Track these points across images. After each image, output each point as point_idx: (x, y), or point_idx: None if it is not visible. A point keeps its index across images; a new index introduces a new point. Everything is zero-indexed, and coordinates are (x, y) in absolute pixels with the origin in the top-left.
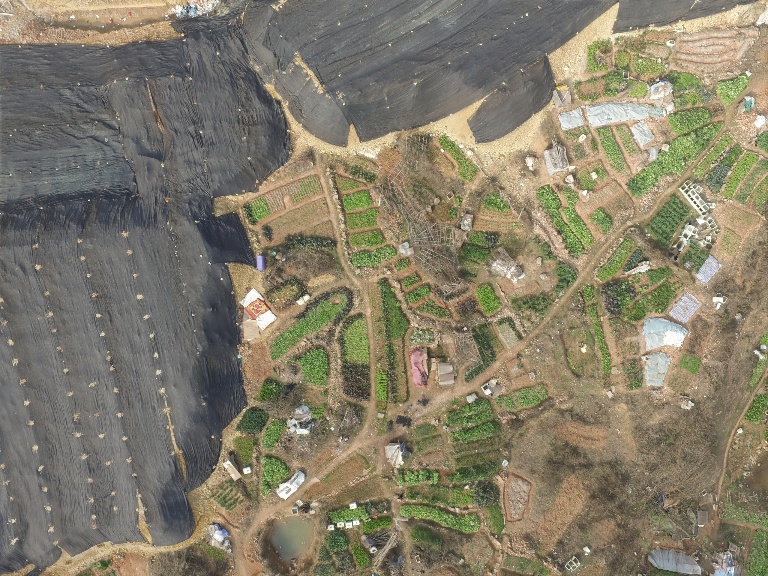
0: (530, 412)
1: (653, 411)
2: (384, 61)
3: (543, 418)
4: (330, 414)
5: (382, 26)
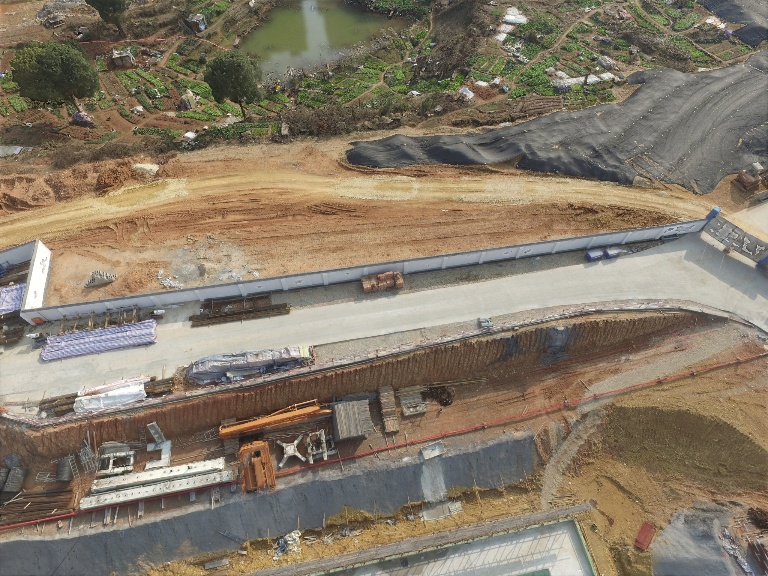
0: (563, 5)
1: (508, 1)
2: (731, 78)
3: (556, 3)
4: (656, 2)
5: (743, 90)
